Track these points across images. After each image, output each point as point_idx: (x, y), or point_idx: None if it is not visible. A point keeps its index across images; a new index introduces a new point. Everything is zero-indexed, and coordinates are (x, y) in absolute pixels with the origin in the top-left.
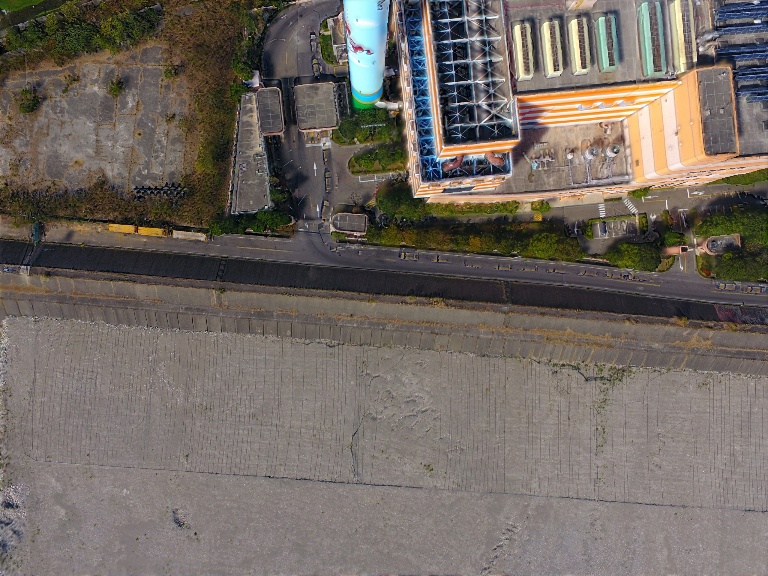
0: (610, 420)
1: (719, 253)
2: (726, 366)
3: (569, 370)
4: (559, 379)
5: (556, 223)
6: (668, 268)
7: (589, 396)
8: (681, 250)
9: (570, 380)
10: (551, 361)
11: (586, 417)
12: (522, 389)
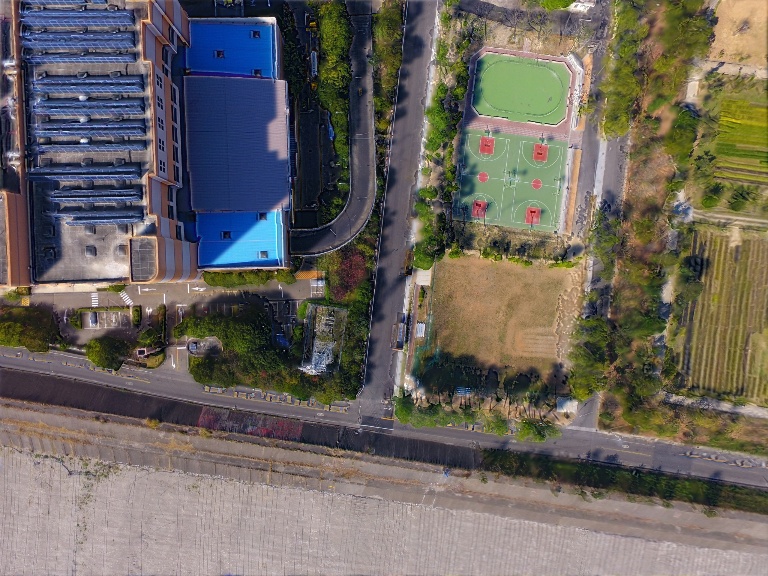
0: (92, 517)
1: (200, 355)
2: (214, 470)
3: (52, 462)
4: (41, 471)
5: (42, 310)
6: (158, 365)
7: (72, 490)
8: (138, 353)
9: (53, 473)
10: (34, 452)
11: (67, 512)
12: (1, 478)
